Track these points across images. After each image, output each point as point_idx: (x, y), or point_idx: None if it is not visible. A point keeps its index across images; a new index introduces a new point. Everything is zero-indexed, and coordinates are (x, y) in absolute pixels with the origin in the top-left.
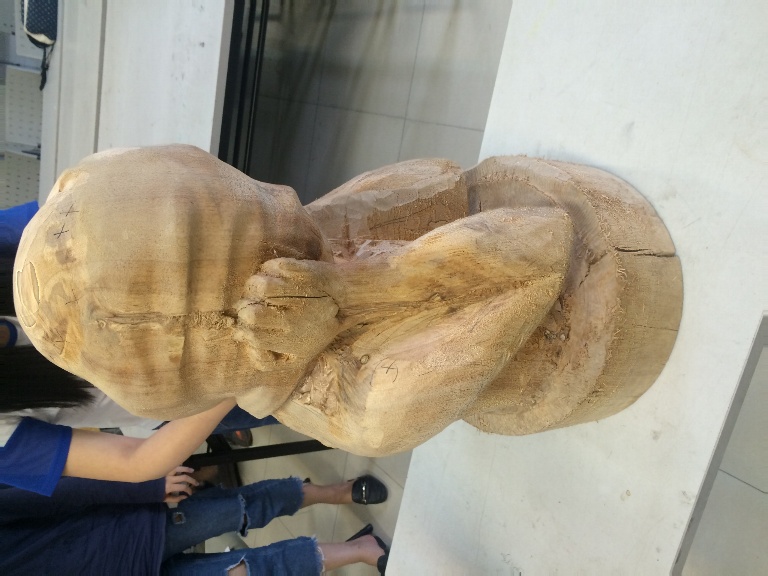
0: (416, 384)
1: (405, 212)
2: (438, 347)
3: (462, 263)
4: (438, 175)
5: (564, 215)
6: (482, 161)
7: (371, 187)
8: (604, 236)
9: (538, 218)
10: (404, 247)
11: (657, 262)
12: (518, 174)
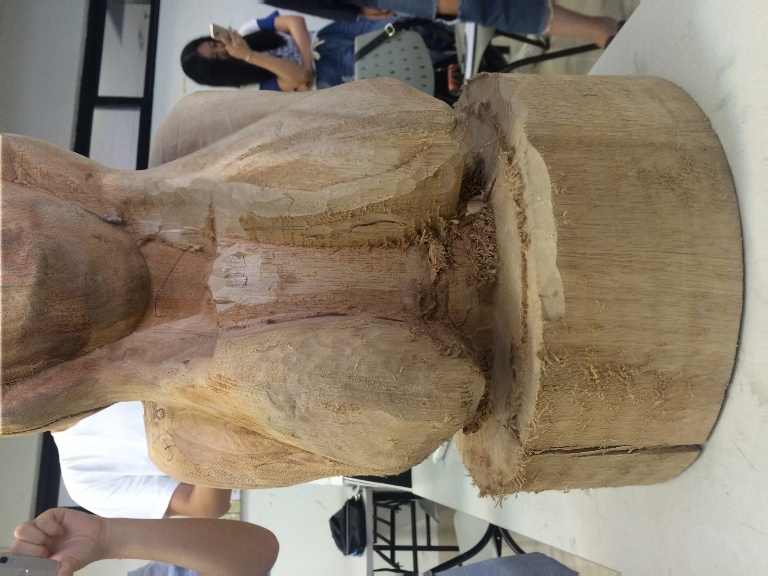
0: (186, 476)
1: (301, 222)
2: (218, 459)
3: (248, 425)
4: (384, 172)
5: (444, 417)
6: (521, 124)
7: (252, 178)
8: (525, 435)
9: (386, 417)
10: (186, 374)
11: (632, 460)
12: (528, 216)
